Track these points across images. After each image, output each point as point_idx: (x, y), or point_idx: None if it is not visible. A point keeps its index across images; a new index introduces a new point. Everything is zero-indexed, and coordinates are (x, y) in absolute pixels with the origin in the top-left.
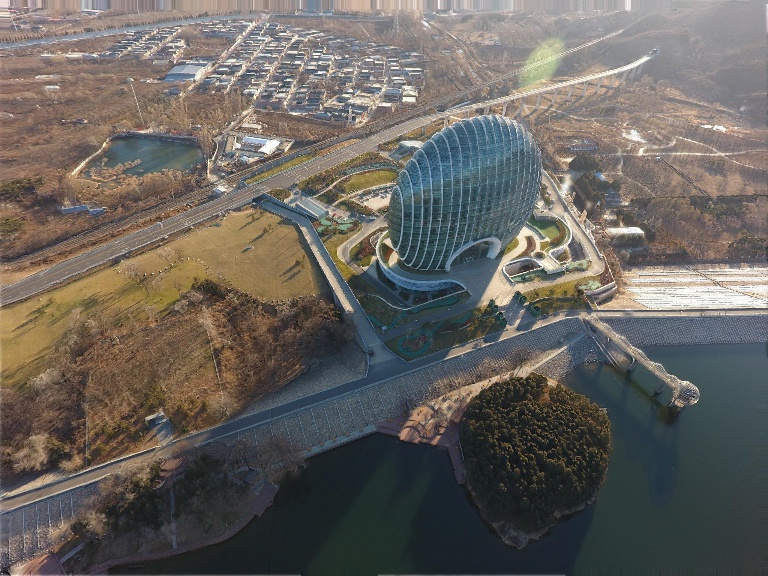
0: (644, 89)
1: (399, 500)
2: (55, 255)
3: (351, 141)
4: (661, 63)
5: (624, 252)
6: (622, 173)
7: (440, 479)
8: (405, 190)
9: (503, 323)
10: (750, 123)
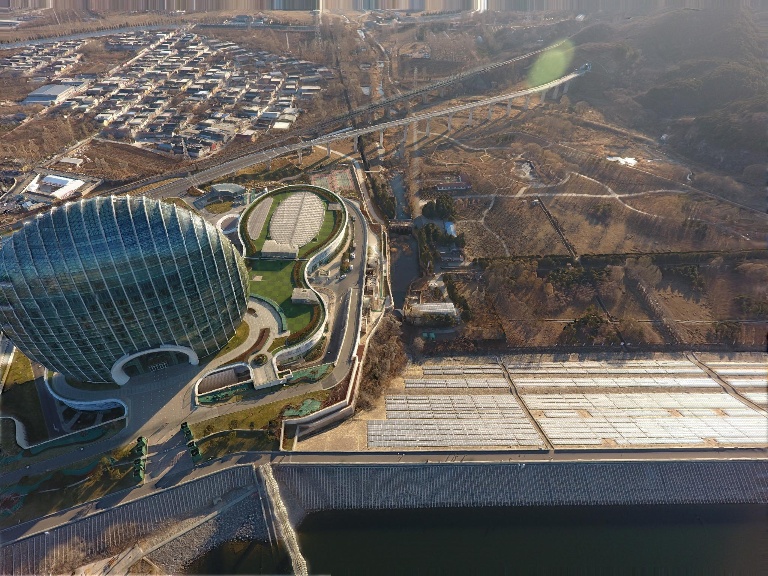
0: (562, 111)
1: None
2: None
3: (167, 181)
4: (591, 80)
5: (417, 340)
6: (483, 221)
7: None
8: None
9: (133, 477)
10: (668, 154)
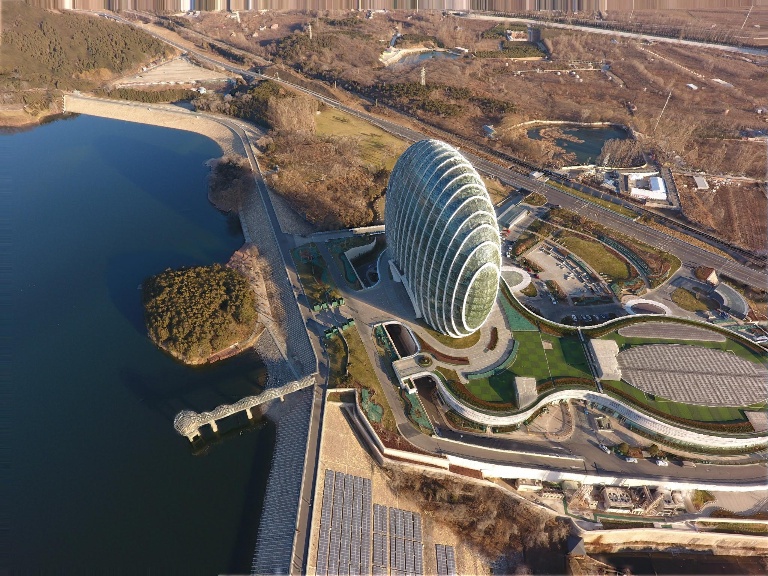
0: None
1: None
2: (432, 132)
3: (714, 250)
4: None
5: (525, 570)
6: None
7: None
8: None
9: (314, 304)
10: None
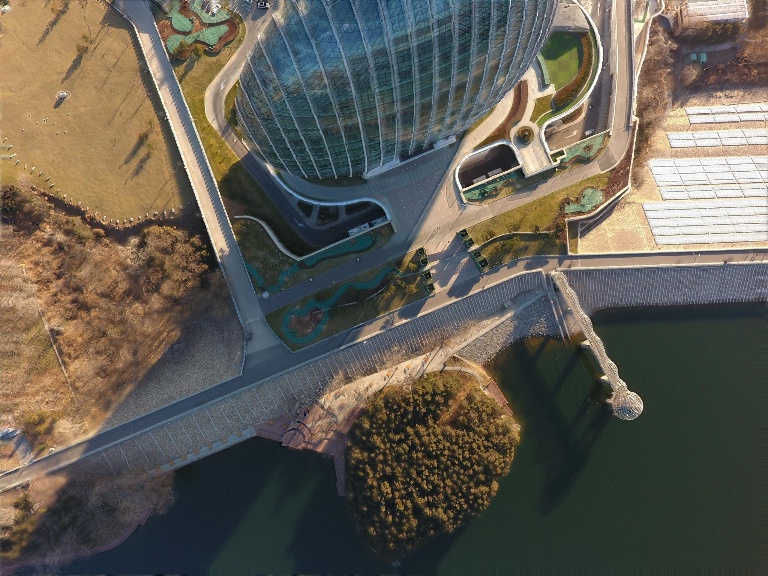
0: None
1: (278, 510)
2: None
3: None
4: None
5: (689, 71)
6: None
7: (323, 484)
8: (251, 123)
9: None
10: None
